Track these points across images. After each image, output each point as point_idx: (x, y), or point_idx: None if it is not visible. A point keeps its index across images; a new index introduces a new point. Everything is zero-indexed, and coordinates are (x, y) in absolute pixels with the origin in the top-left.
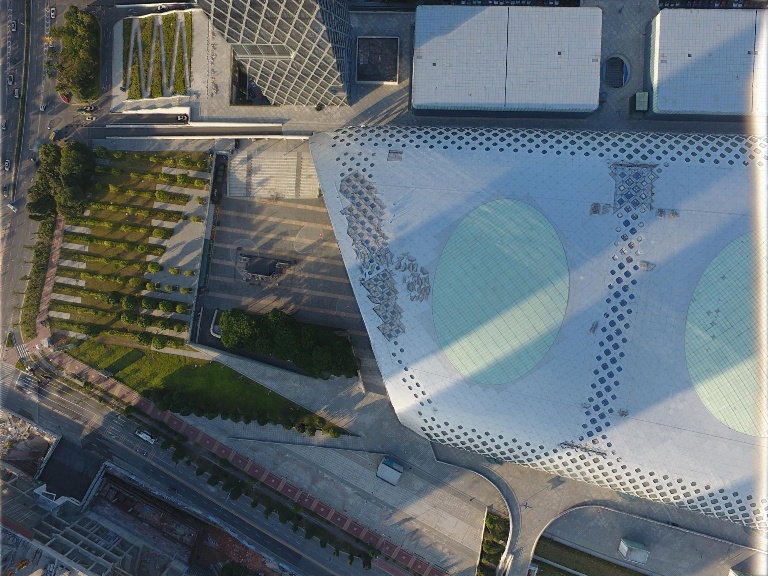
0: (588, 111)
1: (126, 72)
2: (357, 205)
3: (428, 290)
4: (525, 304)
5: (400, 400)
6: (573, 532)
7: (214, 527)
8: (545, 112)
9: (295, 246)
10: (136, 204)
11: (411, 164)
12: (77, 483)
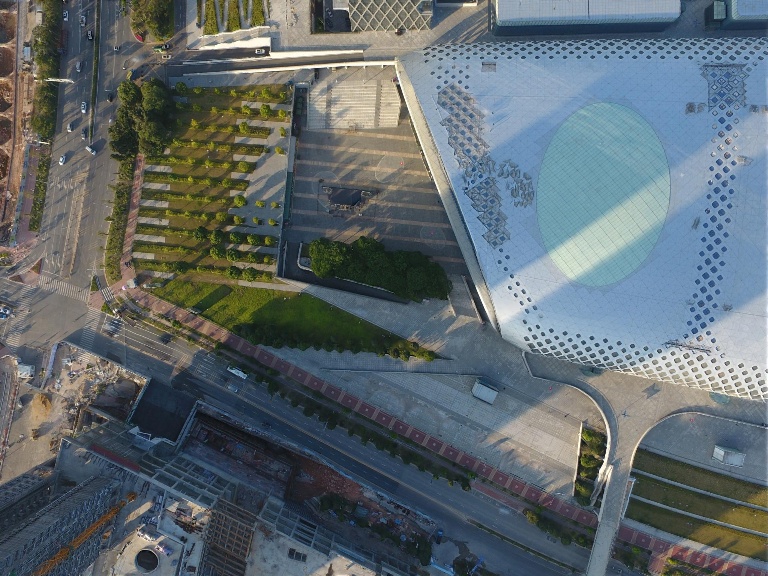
0: (670, 20)
1: (200, 8)
2: (456, 116)
3: (532, 195)
4: (629, 203)
5: (505, 309)
6: (667, 442)
7: (307, 462)
8: (627, 24)
9: (376, 176)
10: (217, 140)
11: (506, 74)
12: (169, 424)
